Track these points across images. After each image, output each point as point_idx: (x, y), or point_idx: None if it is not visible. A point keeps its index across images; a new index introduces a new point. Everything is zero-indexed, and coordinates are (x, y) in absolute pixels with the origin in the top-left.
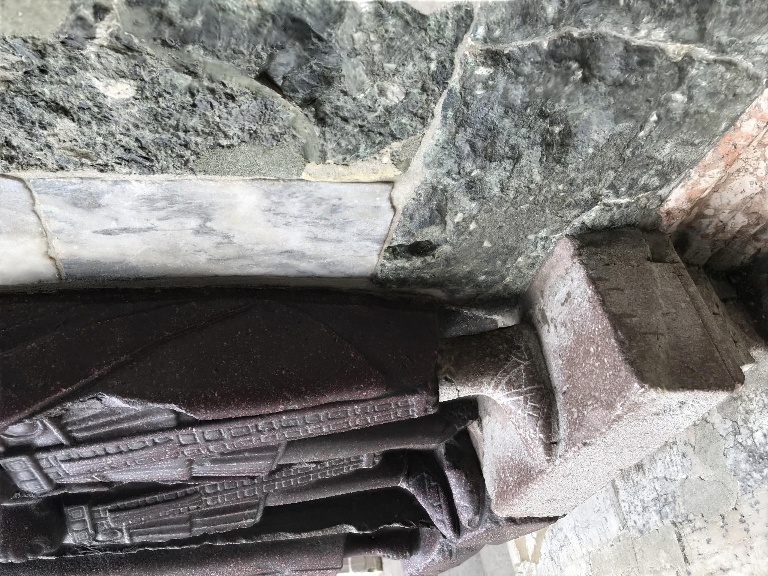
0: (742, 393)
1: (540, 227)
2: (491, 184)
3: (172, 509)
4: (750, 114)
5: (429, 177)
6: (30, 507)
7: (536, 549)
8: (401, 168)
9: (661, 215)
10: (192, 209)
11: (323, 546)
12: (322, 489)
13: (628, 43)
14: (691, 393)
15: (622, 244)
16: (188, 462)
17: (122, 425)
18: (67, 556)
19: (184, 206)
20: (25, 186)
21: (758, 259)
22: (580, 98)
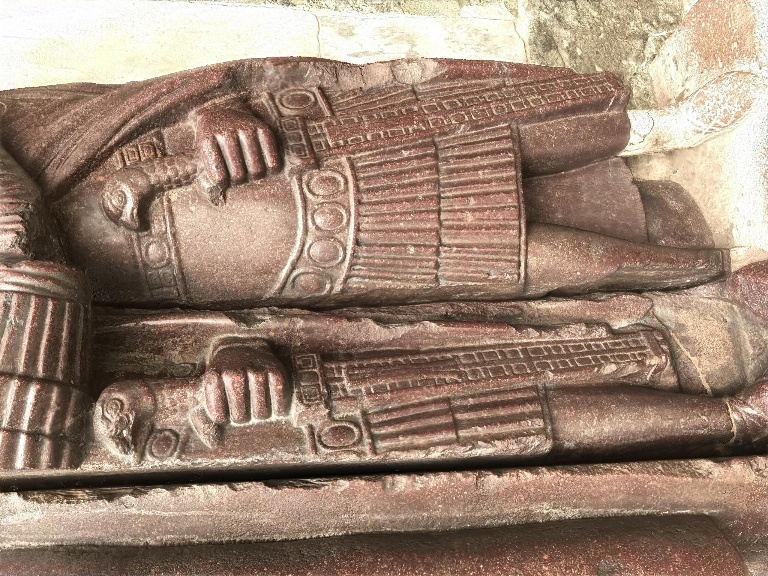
0: None
1: (624, 54)
2: (571, 22)
3: (424, 377)
4: None
5: (532, 17)
6: (253, 348)
7: None
8: (514, 15)
9: None
10: (404, 37)
11: (690, 536)
12: (619, 397)
13: None
14: None
15: None
16: (434, 148)
17: (375, 106)
18: (278, 490)
19: (399, 35)
20: (317, 20)
21: None
22: None
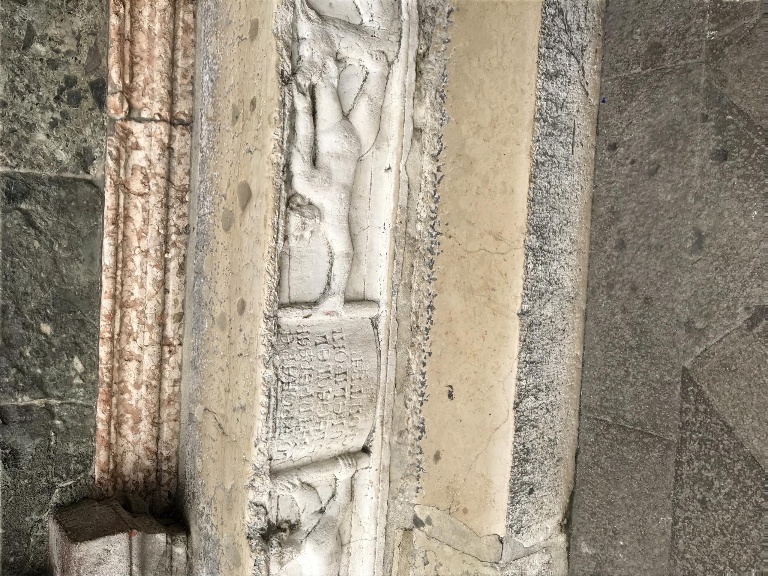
0: (196, 570)
1: (30, 511)
2: None
3: None
4: (98, 421)
5: None
6: None
7: None
8: None
9: (99, 486)
10: None
11: None
12: None
13: (18, 405)
14: (105, 539)
15: (81, 506)
16: None
17: None
18: None
19: None
20: None
21: (175, 498)
22: (9, 433)
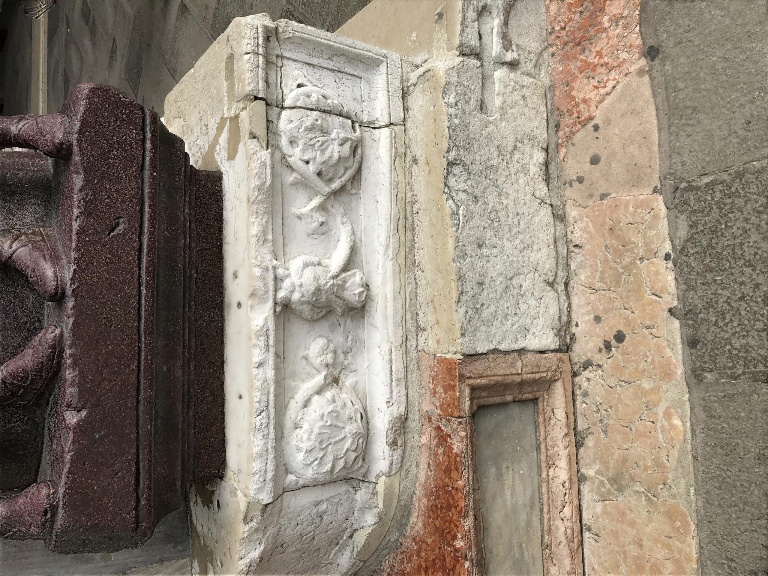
0: None
1: None
2: None
3: None
4: None
5: None
6: None
7: (219, 133)
8: None
9: None
10: None
11: None
12: None
13: None
14: None
15: None
16: None
17: None
18: None
19: None
20: None
21: None
22: None
